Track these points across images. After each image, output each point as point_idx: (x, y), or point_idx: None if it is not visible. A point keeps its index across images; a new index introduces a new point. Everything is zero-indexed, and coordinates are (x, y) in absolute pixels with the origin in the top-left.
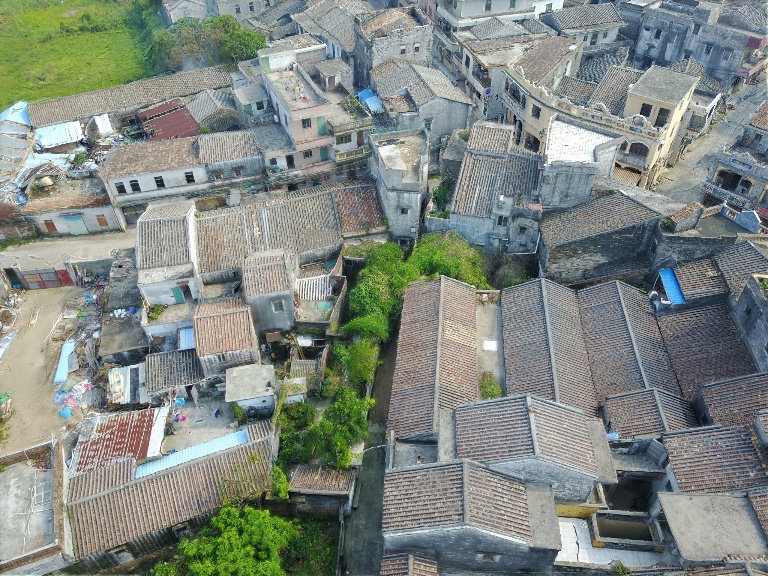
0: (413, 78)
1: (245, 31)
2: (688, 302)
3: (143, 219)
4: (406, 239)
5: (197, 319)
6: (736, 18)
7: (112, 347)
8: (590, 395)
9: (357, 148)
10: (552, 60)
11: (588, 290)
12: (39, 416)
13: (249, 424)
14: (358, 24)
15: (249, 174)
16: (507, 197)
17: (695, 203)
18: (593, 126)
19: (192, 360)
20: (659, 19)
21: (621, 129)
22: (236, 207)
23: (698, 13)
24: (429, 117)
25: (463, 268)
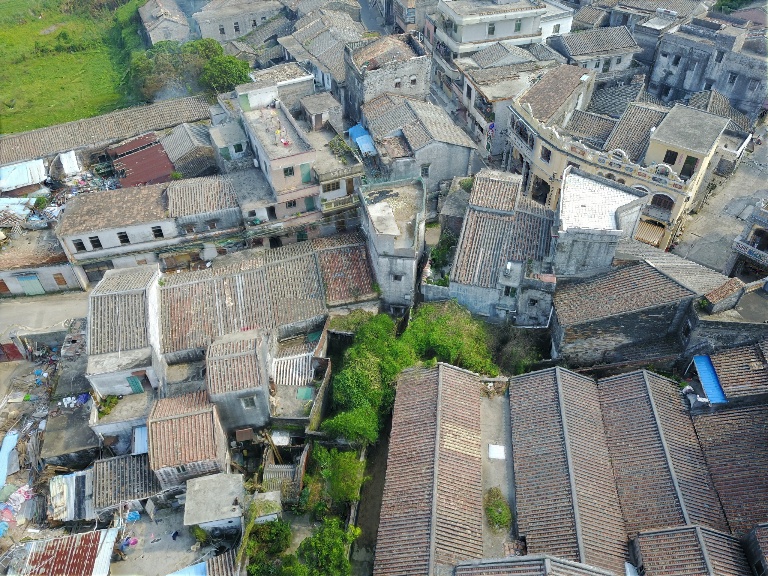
0: (409, 117)
1: (227, 57)
2: (730, 401)
3: (97, 292)
4: (400, 307)
5: (152, 423)
6: (764, 45)
7: (57, 447)
8: (617, 525)
9: (346, 196)
10: (563, 93)
11: (610, 380)
12: None
13: (213, 546)
14: (349, 54)
15: (225, 227)
16: (515, 263)
17: (736, 281)
18: (614, 182)
19: (148, 466)
20: (678, 45)
21: (643, 179)
22: (208, 269)
23: (722, 40)
24: (427, 162)
25: (465, 348)
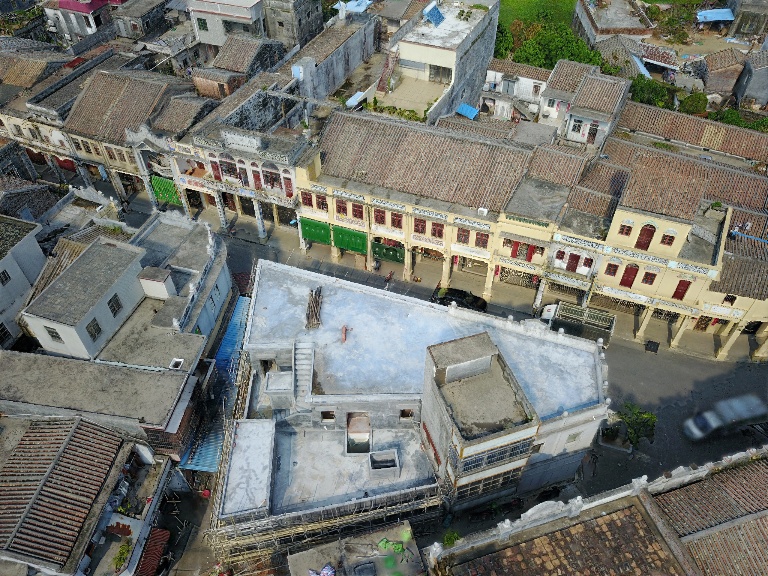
0: None
1: None
2: None
3: None
4: None
5: None
6: None
7: None
8: None
9: None
10: None
11: (764, 210)
12: (685, 51)
13: None
14: None
15: None
16: None
17: None
18: None
19: None
20: None
21: None
22: None
23: None
24: None
25: None
